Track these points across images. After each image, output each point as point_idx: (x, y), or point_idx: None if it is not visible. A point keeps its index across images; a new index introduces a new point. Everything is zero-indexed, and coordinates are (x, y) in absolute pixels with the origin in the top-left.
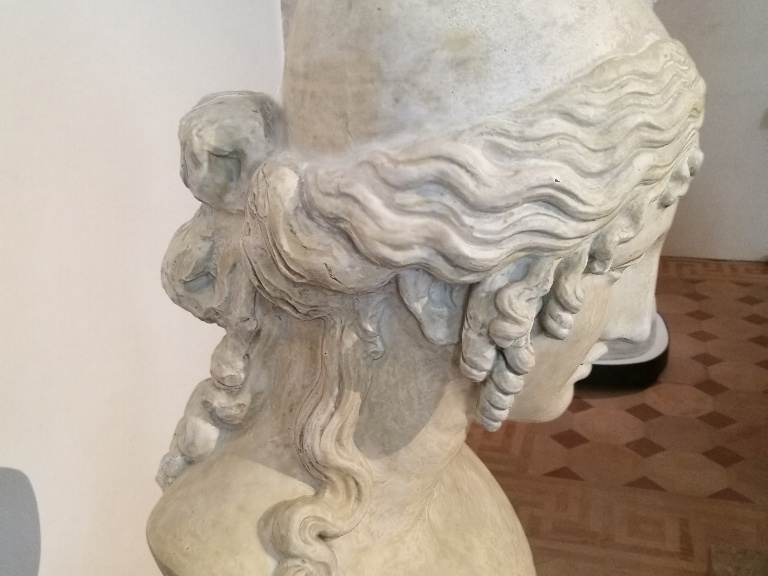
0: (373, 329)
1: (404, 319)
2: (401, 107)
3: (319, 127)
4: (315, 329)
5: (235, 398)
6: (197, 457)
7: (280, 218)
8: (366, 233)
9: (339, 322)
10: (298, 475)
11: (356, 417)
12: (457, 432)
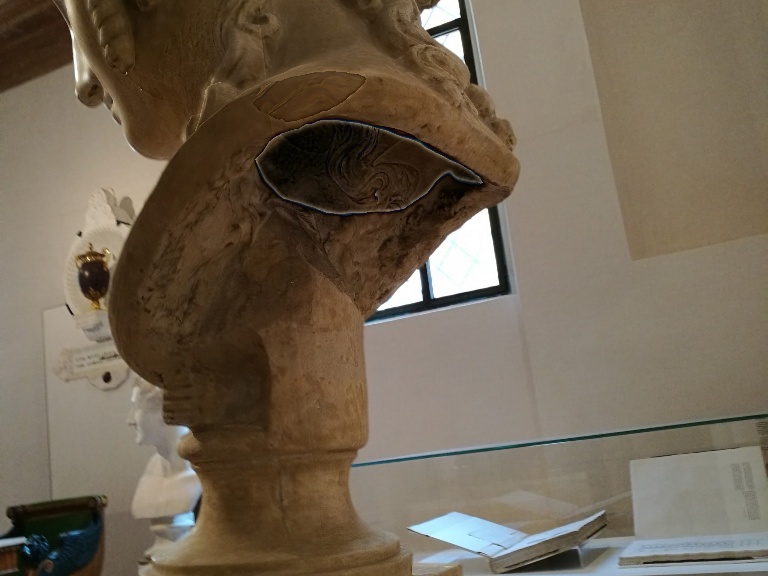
0: None
1: None
2: None
3: None
4: None
5: None
6: None
7: None
8: None
9: None
10: (383, 149)
11: None
12: None
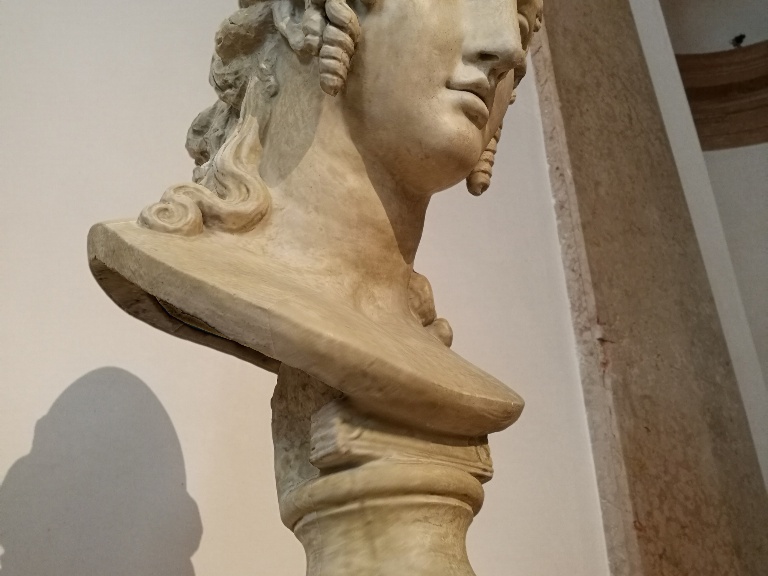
0: (266, 67)
1: (290, 59)
2: None
3: None
4: None
5: None
6: None
7: None
8: None
9: None
10: None
11: (258, 145)
12: (355, 171)
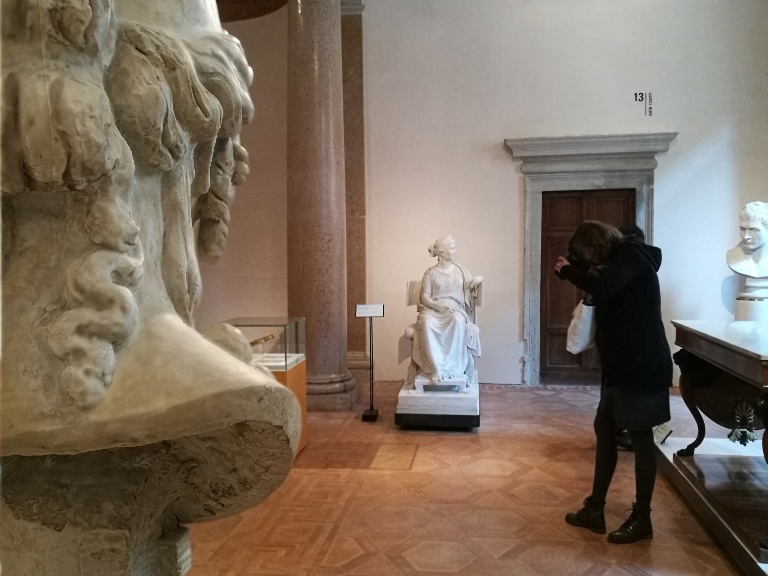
0: None
1: None
2: (206, 7)
3: (161, 6)
4: (155, 185)
5: (138, 257)
6: (134, 330)
7: (193, 66)
8: (235, 84)
9: (184, 170)
10: None
11: None
12: None
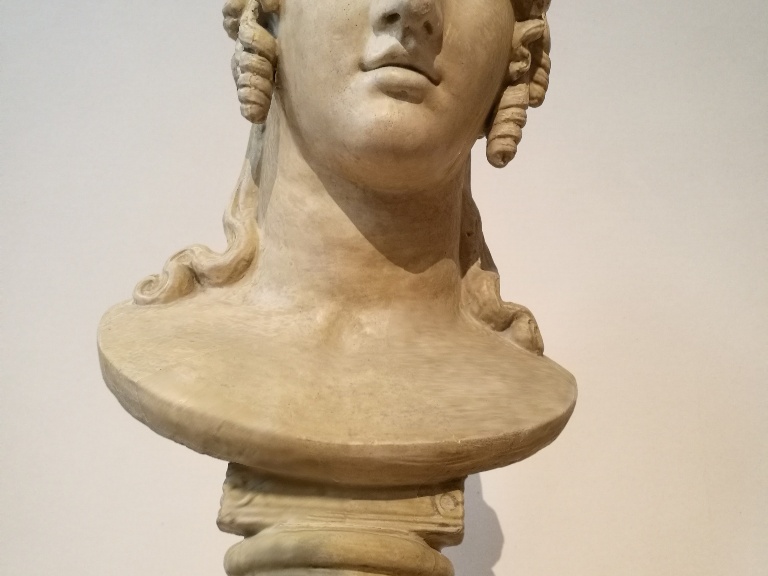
0: None
1: None
2: None
3: None
4: None
5: None
6: None
7: None
8: None
9: None
10: None
11: (253, 187)
12: (314, 192)
